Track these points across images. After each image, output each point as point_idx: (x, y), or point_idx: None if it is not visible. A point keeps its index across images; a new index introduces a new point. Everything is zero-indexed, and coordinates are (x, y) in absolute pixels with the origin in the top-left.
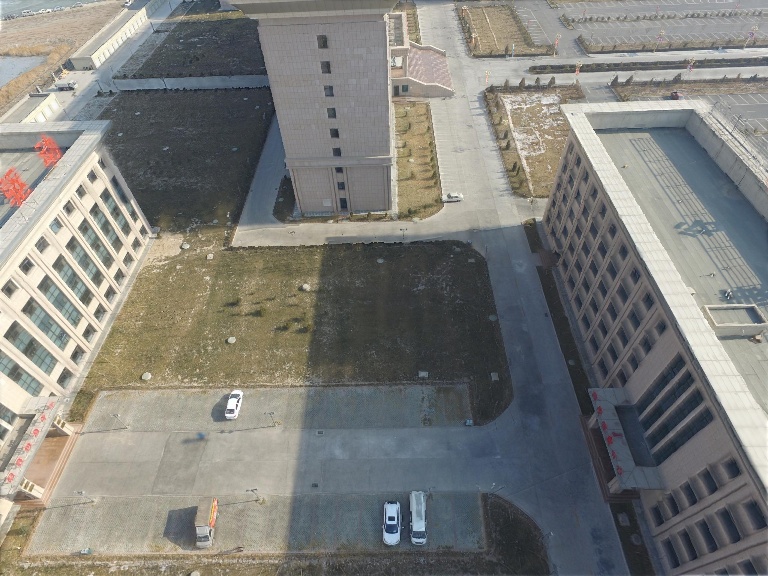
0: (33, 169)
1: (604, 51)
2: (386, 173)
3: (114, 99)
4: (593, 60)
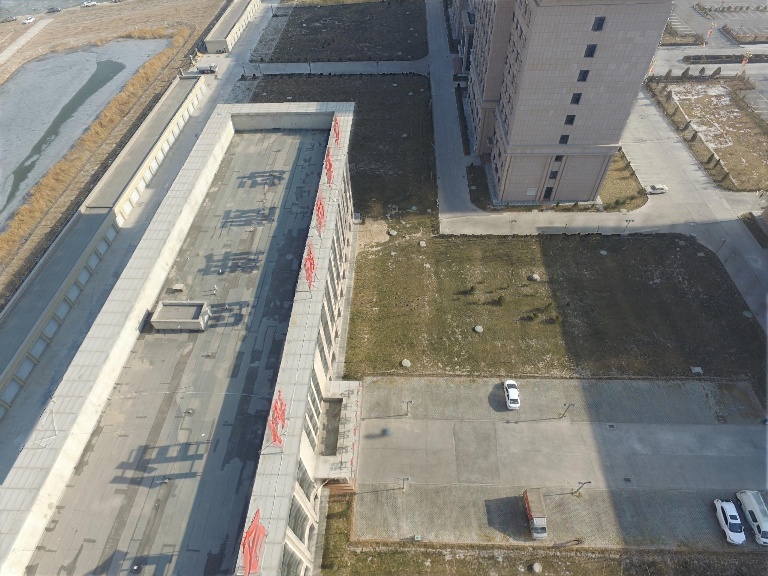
0: (285, 150)
1: (756, 42)
2: (606, 162)
3: (259, 83)
4: (747, 51)
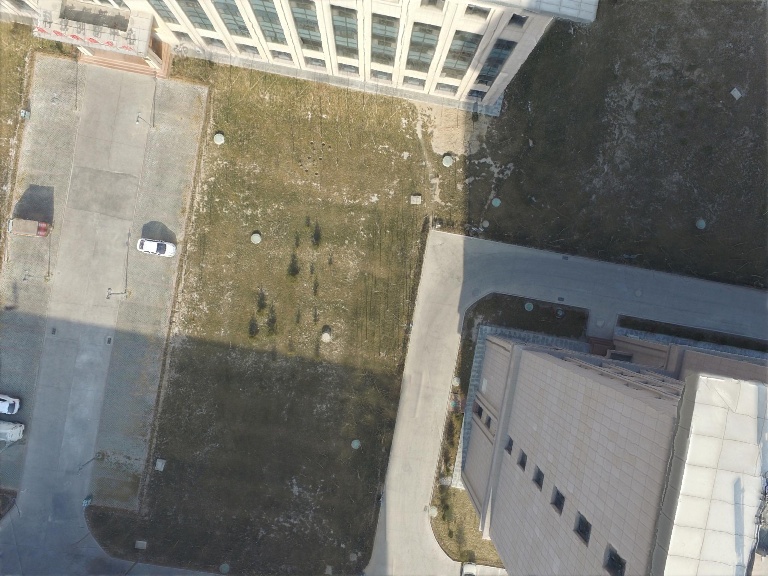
0: None
1: None
2: (479, 508)
3: None
4: None
